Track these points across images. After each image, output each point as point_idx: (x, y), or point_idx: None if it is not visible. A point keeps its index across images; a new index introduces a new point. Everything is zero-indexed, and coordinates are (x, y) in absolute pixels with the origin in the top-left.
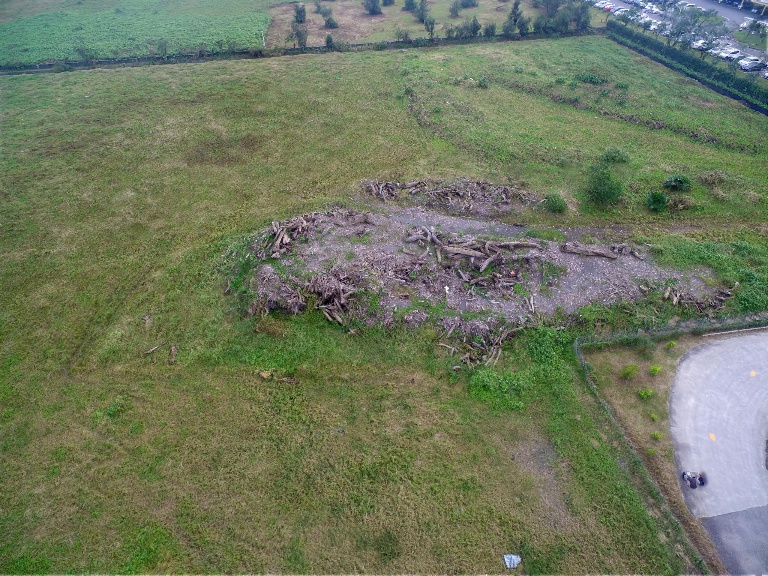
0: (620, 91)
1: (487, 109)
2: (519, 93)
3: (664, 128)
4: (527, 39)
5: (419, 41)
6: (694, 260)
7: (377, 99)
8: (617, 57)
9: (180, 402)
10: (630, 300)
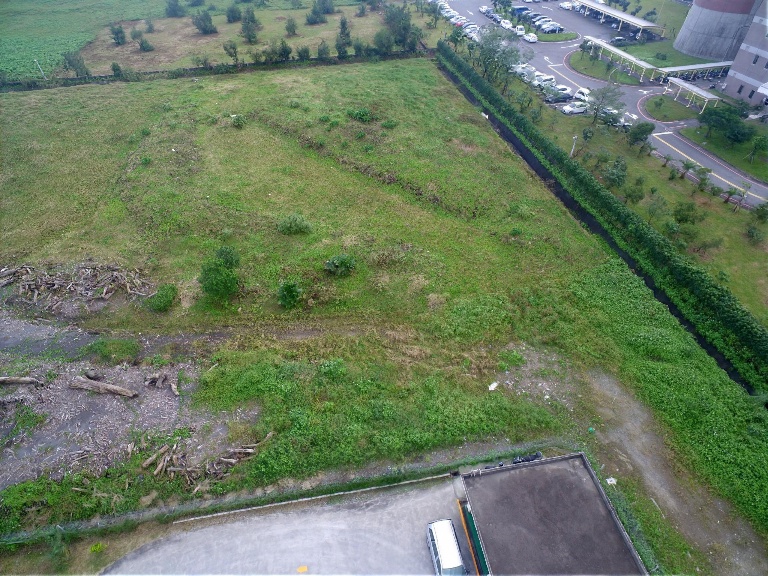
0: (382, 132)
1: (216, 157)
2: (273, 134)
3: (394, 182)
4: (347, 63)
5: (219, 67)
6: (246, 394)
7: (105, 144)
8: (418, 86)
9: None
10: (98, 469)
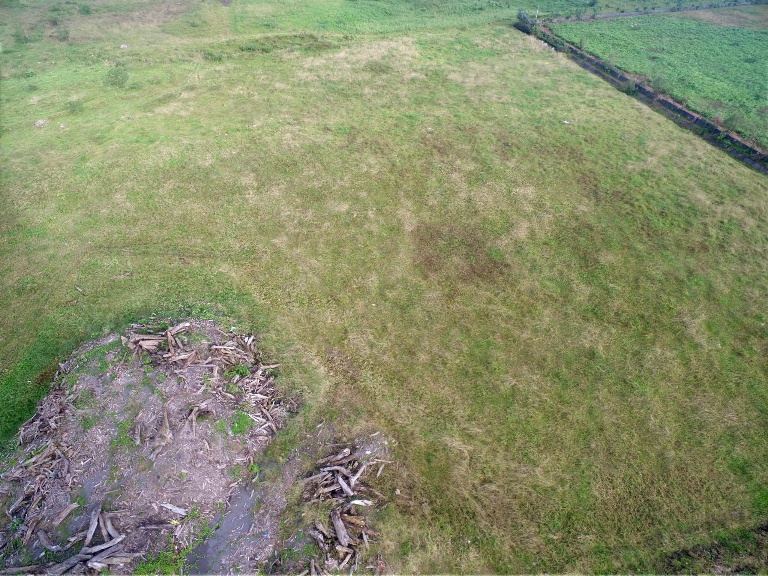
0: None
1: None
2: None
3: None
4: None
5: None
6: None
7: None
8: None
9: (8, 323)
10: None
